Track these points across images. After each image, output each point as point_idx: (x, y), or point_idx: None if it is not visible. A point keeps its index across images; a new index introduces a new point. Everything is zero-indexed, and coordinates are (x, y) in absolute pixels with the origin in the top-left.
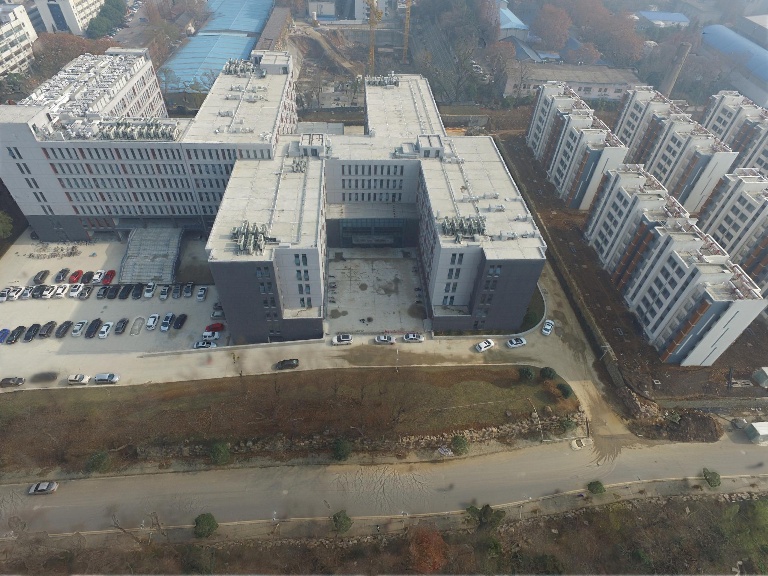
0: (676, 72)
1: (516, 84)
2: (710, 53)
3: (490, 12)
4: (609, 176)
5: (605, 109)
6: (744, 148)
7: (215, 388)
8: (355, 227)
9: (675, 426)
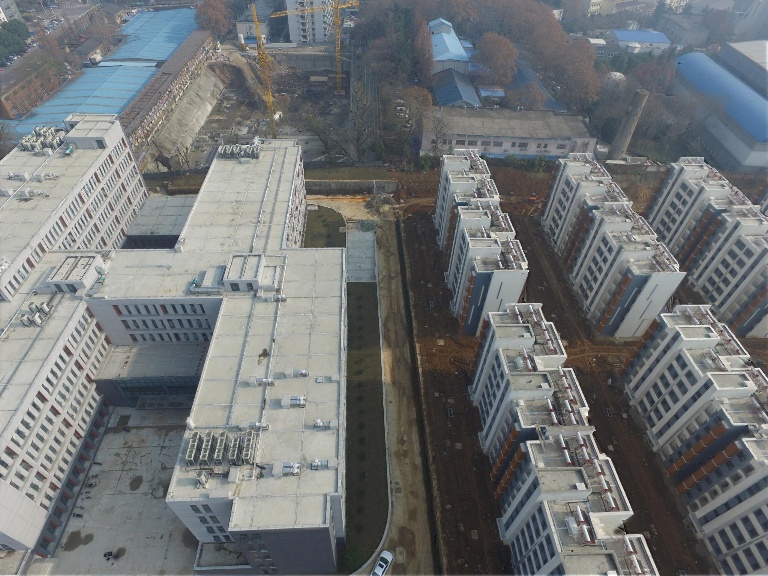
0: (632, 125)
1: (434, 139)
2: (685, 88)
3: (424, 40)
4: (490, 323)
5: (545, 170)
6: (706, 241)
7: None
8: (140, 386)
9: None
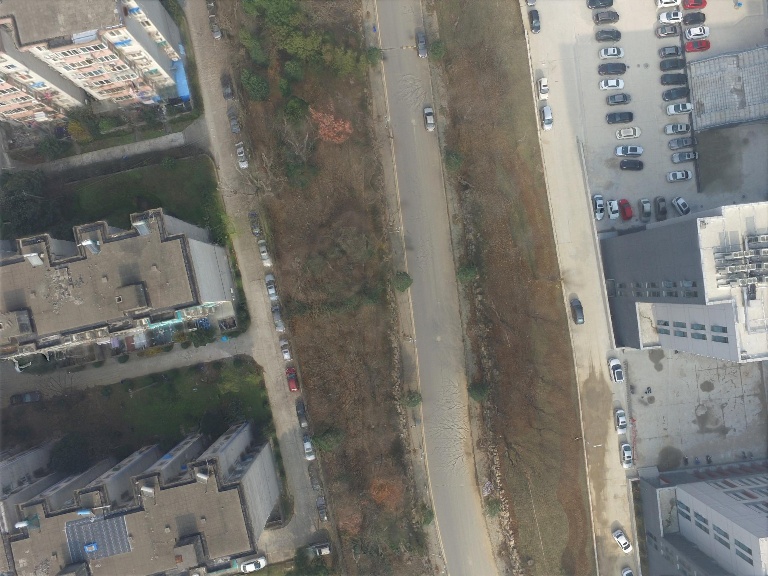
0: None
1: None
2: None
3: None
4: None
5: None
6: None
7: (540, 241)
8: None
9: None
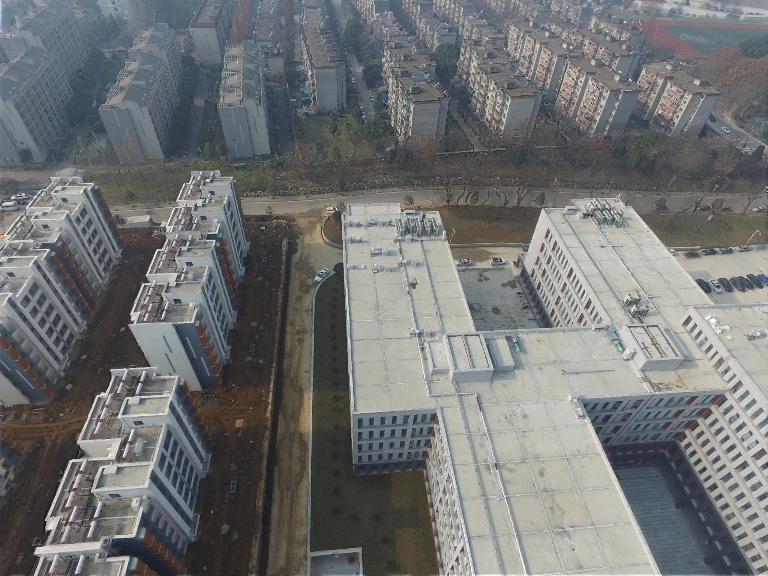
0: None
1: None
2: None
3: None
4: None
5: None
6: None
7: None
8: None
9: (265, 218)
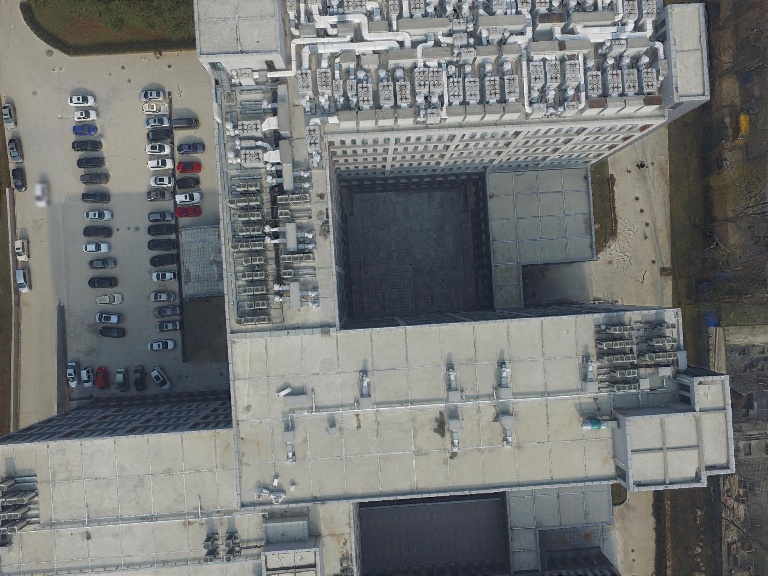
0: None
1: None
2: None
3: None
4: None
5: None
6: None
7: None
8: None
9: None
